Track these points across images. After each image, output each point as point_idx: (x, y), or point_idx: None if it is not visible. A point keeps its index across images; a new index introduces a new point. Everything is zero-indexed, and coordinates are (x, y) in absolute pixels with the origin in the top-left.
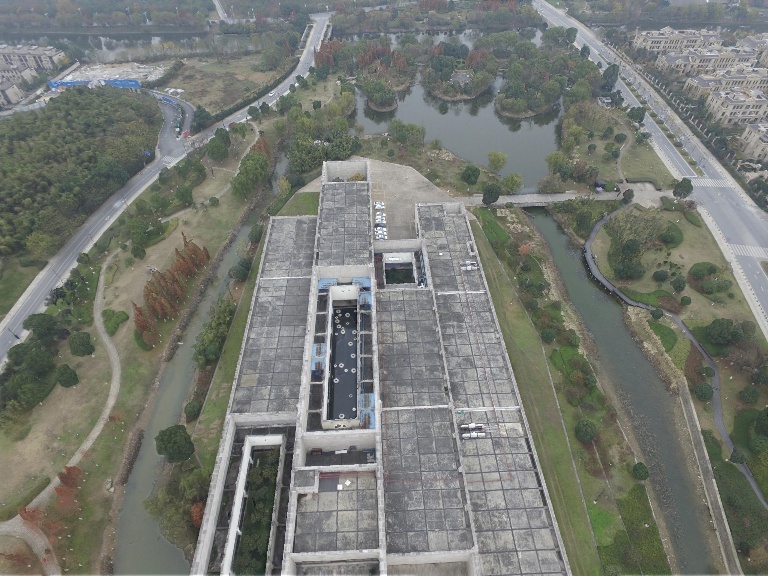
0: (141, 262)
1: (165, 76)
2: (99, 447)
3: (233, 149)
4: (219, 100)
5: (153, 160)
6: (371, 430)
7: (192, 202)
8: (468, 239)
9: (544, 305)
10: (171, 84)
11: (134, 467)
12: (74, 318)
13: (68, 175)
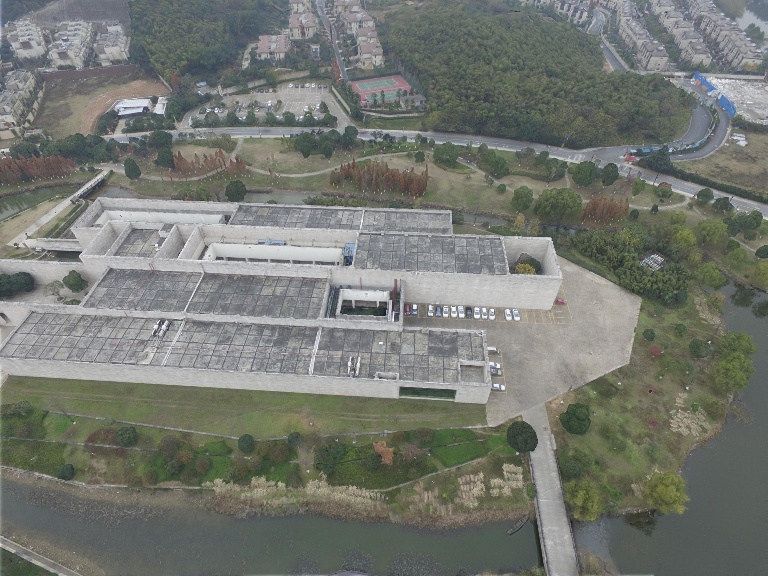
0: (417, 164)
1: (765, 126)
2: (264, 177)
3: (611, 192)
4: (735, 172)
5: (574, 149)
6: (180, 256)
7: (500, 177)
8: (408, 378)
9: (301, 466)
10: (756, 135)
11: (250, 193)
12: (367, 150)
13: (509, 106)
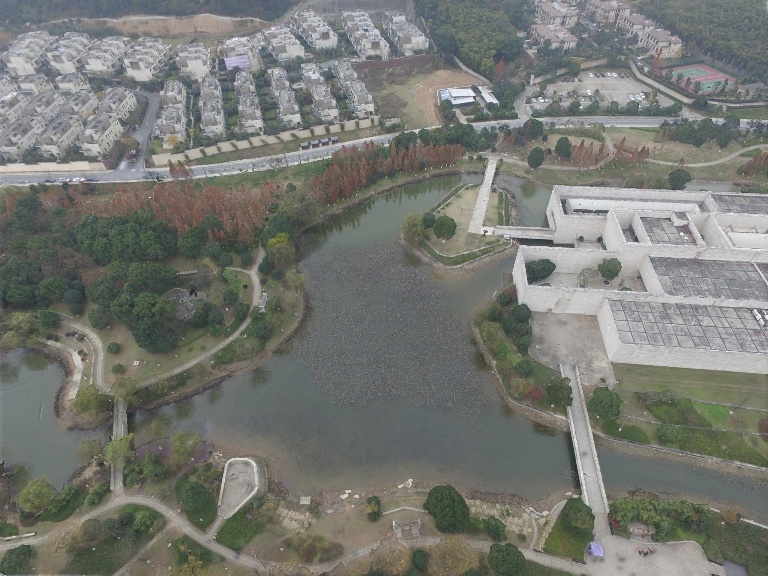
0: None
1: None
2: (662, 167)
3: None
4: None
5: None
6: None
7: None
8: None
9: None
10: None
11: None
12: None
13: None
